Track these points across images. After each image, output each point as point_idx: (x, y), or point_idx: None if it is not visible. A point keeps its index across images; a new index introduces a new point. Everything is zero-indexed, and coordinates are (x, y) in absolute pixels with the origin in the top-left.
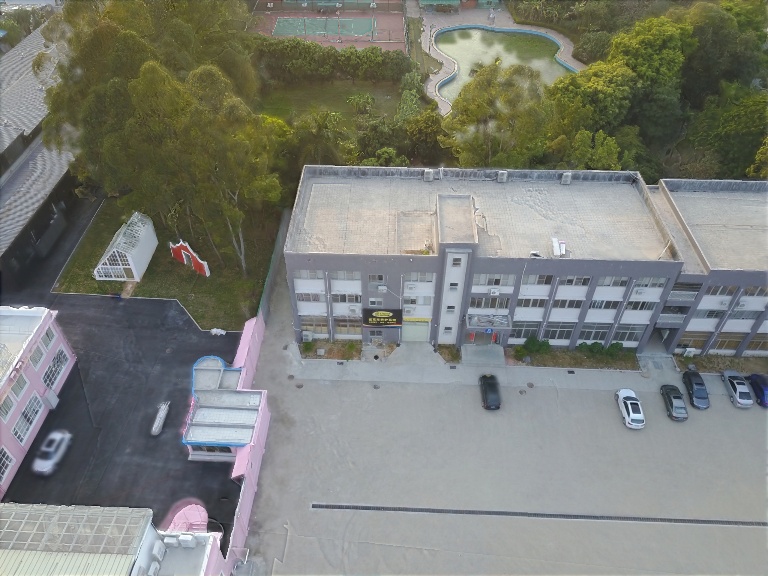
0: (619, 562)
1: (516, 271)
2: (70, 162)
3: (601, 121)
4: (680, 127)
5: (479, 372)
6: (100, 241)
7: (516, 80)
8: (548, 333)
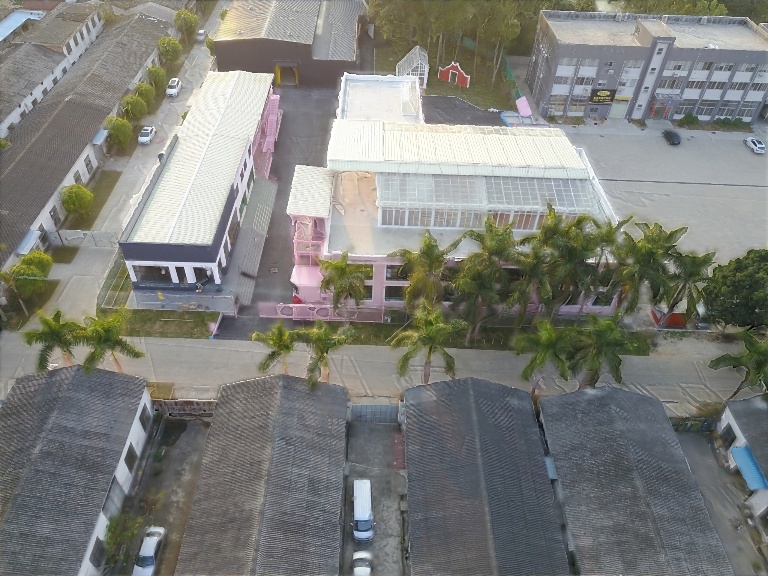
0: (767, 199)
1: (693, 59)
2: (387, 6)
3: None
4: (748, 16)
5: (660, 131)
6: (385, 70)
7: None
8: (699, 110)
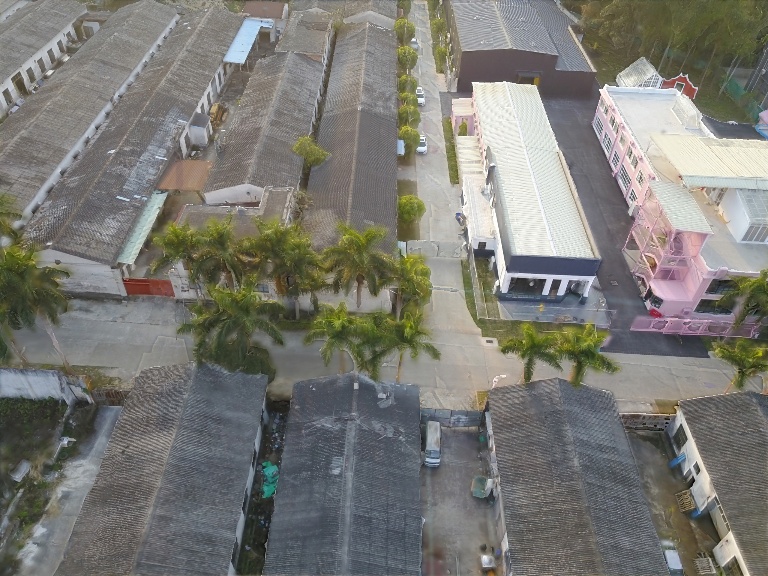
0: None
1: None
2: (622, 18)
3: None
4: None
5: None
6: (605, 80)
7: None
8: None
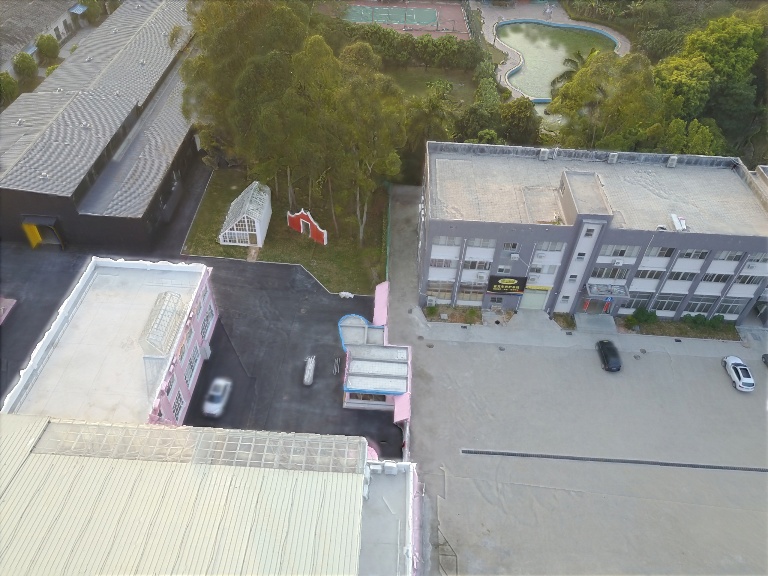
0: (748, 505)
1: (642, 243)
2: (202, 131)
3: (683, 112)
4: (751, 121)
5: (594, 338)
6: (216, 209)
7: (634, 67)
8: (657, 304)
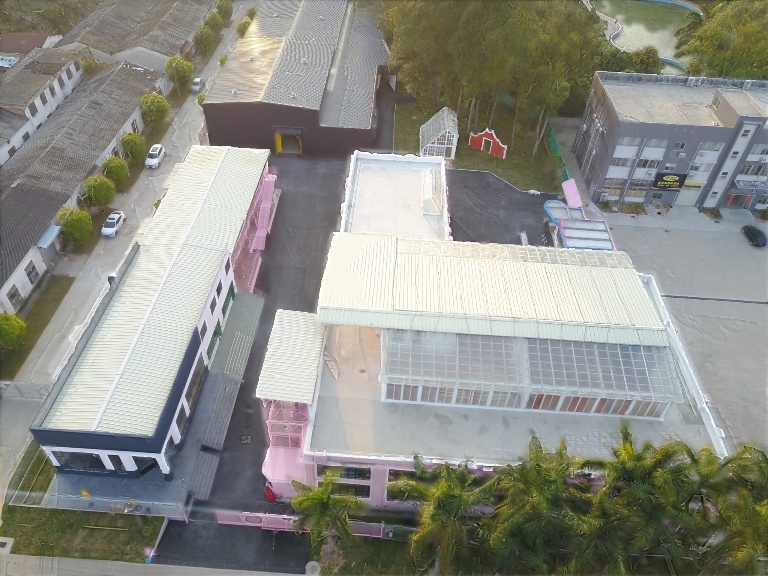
0: None
1: None
2: (411, 63)
3: None
4: None
5: (738, 225)
6: (407, 132)
7: None
8: None
